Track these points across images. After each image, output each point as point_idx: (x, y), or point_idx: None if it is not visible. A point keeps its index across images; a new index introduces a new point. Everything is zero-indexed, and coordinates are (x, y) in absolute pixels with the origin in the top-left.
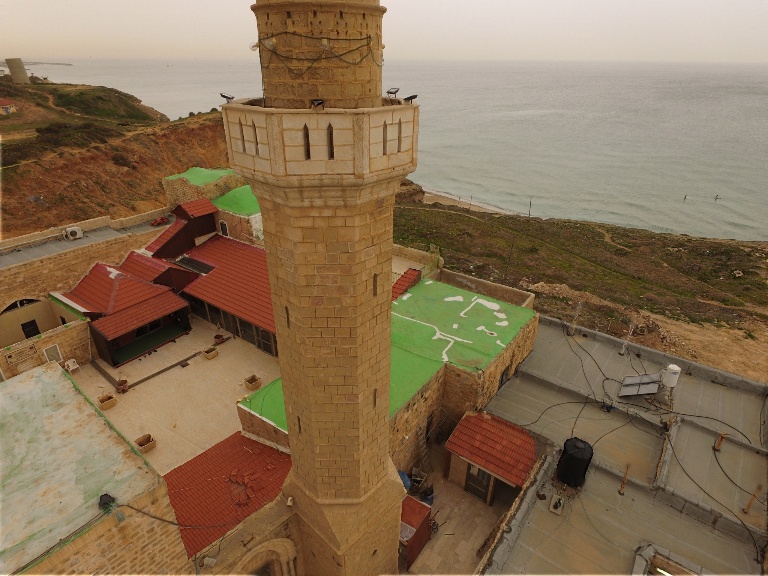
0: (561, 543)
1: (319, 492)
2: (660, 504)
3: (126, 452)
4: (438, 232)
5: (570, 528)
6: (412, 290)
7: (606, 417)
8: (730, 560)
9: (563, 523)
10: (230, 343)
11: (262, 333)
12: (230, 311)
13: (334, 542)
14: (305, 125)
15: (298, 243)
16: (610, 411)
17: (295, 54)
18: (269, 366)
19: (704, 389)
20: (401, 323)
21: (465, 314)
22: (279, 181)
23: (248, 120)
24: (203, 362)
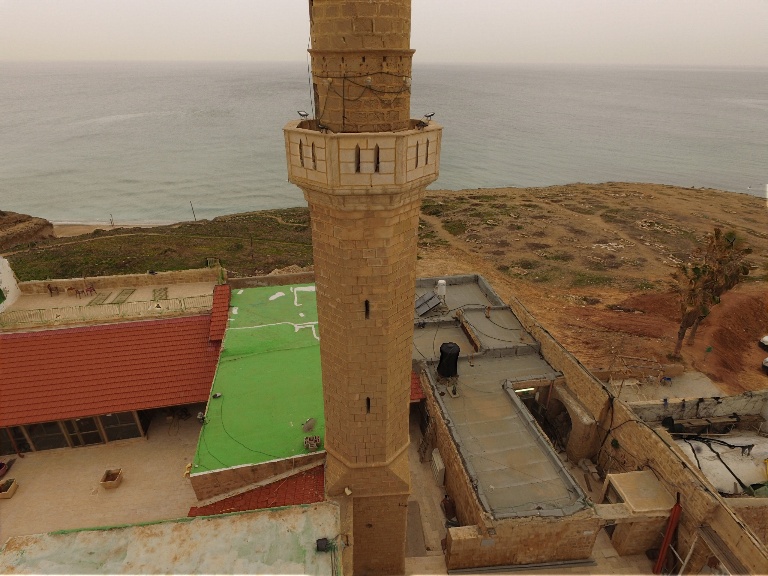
0: (473, 410)
1: (386, 455)
2: (491, 359)
3: (272, 515)
4: (134, 258)
5: (469, 399)
6: (233, 304)
7: (425, 331)
8: (534, 365)
9: (464, 399)
10: (21, 465)
11: (79, 424)
12: (7, 424)
13: (402, 488)
14: (417, 142)
15: (390, 239)
16: (424, 326)
17: (387, 89)
18: (110, 455)
19: (450, 291)
20: (259, 332)
21: (299, 303)
22: (402, 188)
23: (370, 144)
24: (3, 506)
